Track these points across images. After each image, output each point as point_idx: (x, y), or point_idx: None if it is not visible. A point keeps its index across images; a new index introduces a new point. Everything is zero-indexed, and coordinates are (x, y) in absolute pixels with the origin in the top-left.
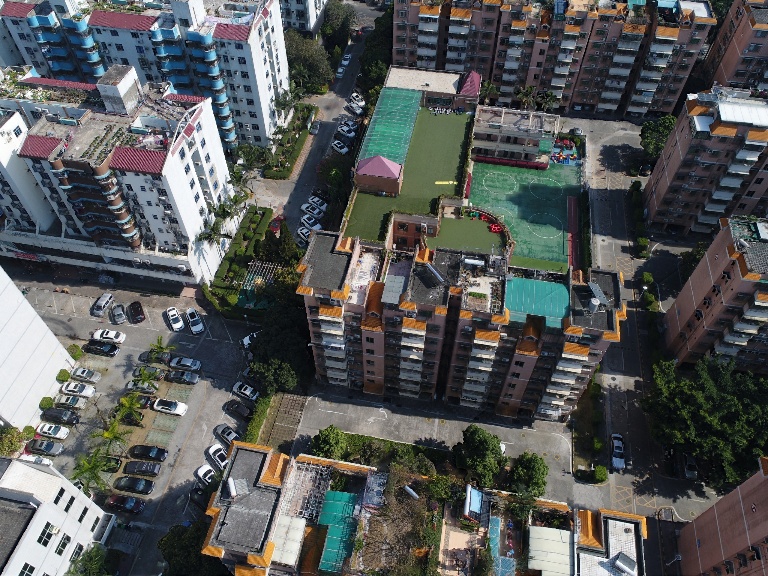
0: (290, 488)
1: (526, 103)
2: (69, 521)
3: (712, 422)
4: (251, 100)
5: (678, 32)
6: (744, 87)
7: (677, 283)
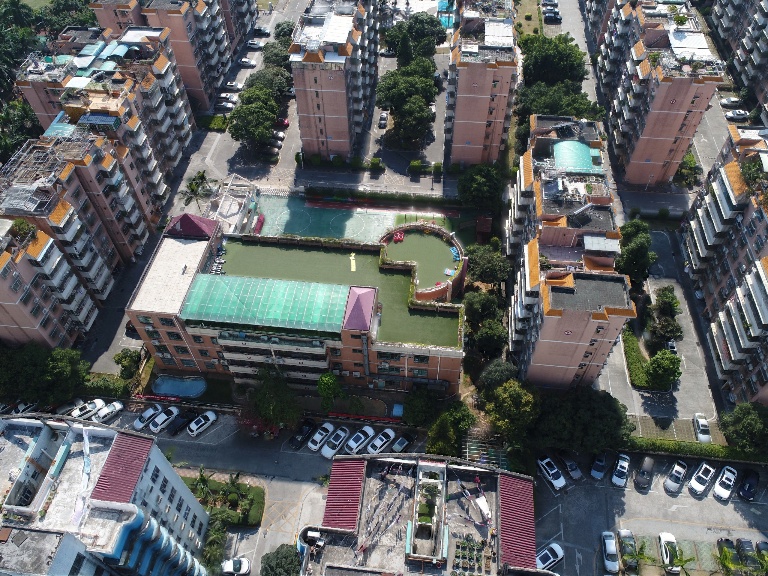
0: None
1: (198, 201)
2: None
3: None
4: (180, 500)
5: (164, 57)
6: (202, 61)
7: (410, 154)
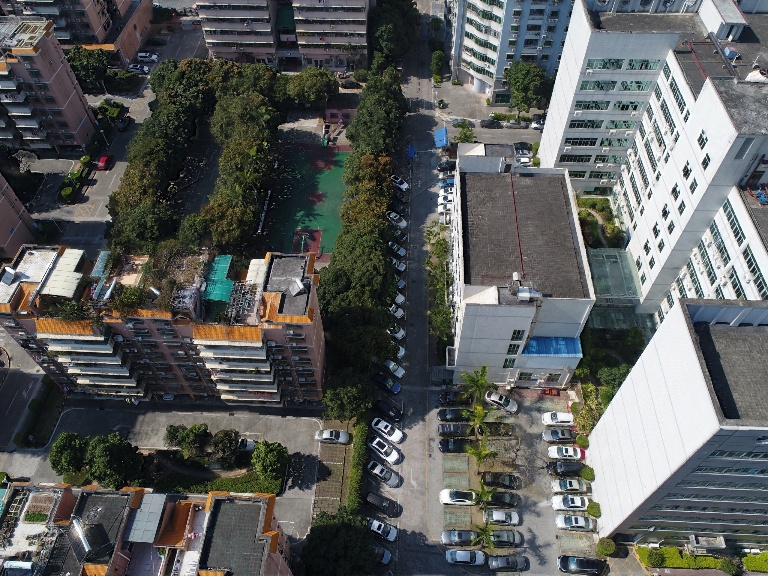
0: (258, 299)
1: None
2: None
3: None
4: None
5: None
6: None
7: None
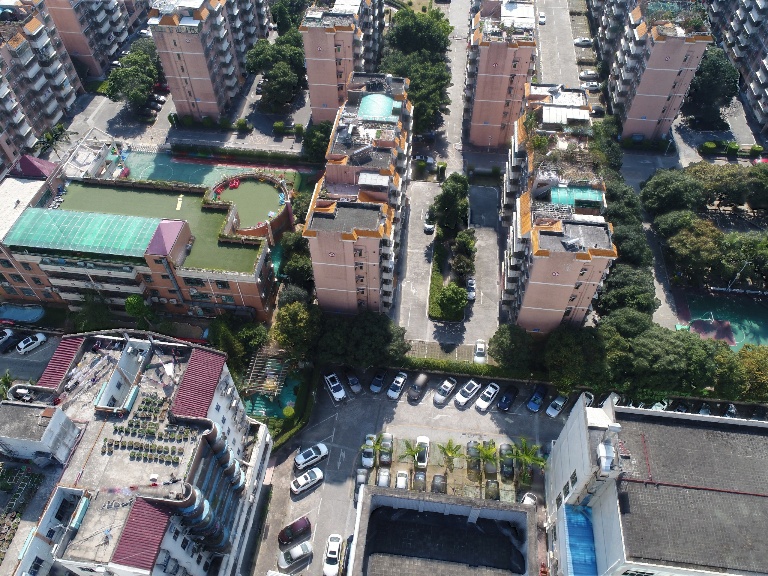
0: None
1: (56, 151)
2: None
3: (425, 91)
4: None
5: (37, 20)
6: (91, 29)
7: (279, 117)
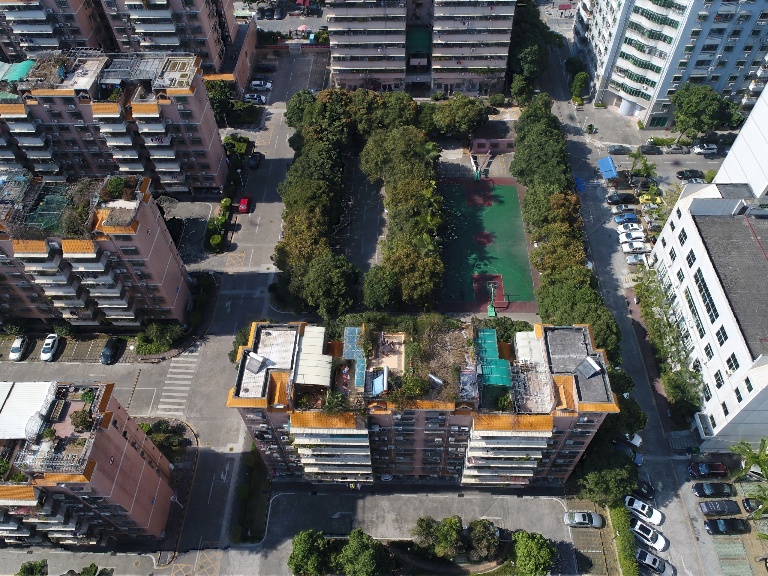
0: (545, 382)
1: None
2: (729, 391)
3: None
4: None
5: None
6: None
7: None
